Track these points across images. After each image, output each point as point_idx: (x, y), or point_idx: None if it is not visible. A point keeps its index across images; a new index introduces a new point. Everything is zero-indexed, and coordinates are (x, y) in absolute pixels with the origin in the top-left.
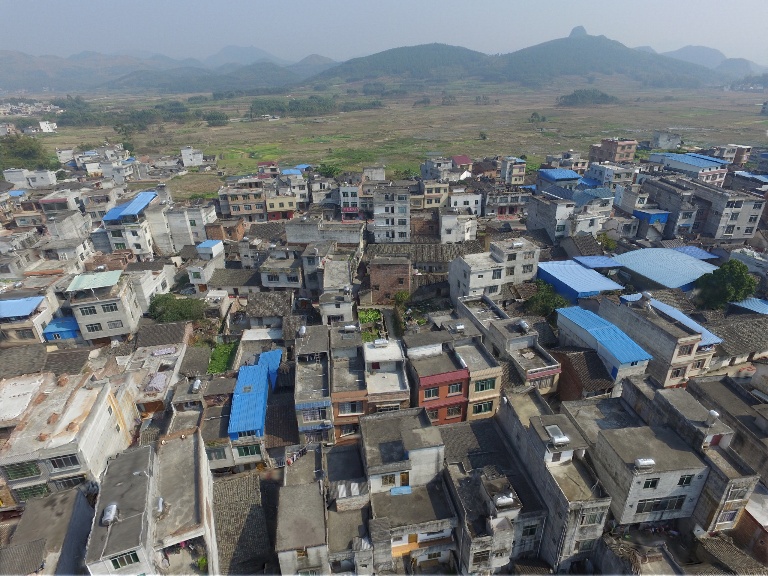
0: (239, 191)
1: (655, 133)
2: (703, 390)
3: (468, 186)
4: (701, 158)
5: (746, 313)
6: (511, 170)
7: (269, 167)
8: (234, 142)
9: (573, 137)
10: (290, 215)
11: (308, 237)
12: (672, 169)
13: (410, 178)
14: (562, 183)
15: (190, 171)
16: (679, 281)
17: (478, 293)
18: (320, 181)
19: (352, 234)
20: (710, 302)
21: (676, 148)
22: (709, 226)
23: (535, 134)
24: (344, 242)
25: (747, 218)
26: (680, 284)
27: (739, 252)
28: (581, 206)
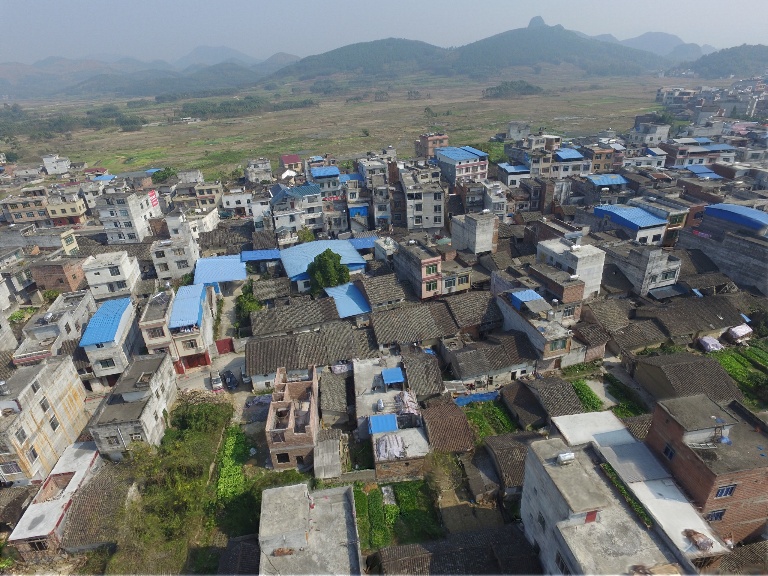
0: (20, 199)
1: (508, 125)
2: None
3: (256, 186)
4: (468, 151)
5: None
6: None
7: (94, 173)
8: (128, 147)
9: (455, 131)
10: (77, 220)
11: (15, 242)
12: (442, 163)
13: (238, 179)
14: (322, 180)
15: (48, 179)
16: (301, 270)
17: (101, 289)
18: (114, 186)
19: (53, 238)
20: (313, 288)
21: None
22: (406, 217)
23: (422, 129)
24: (49, 246)
25: (432, 208)
26: (298, 273)
27: (383, 241)
28: (286, 203)
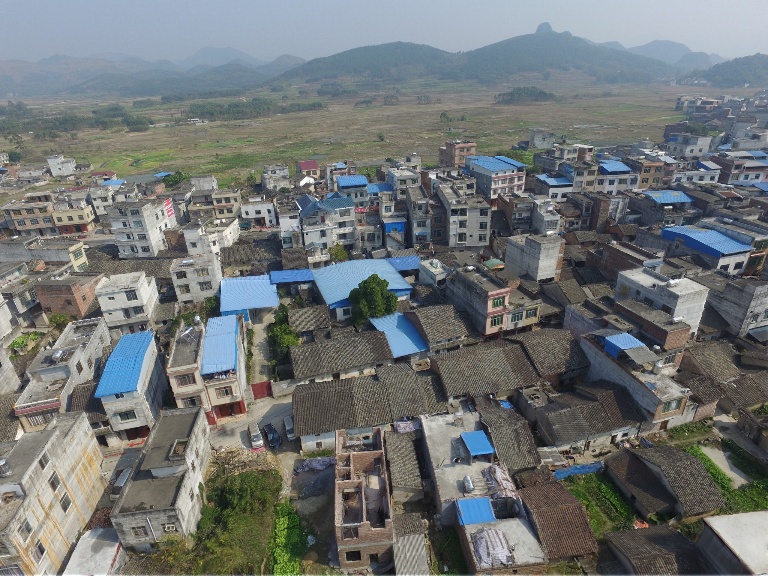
0: (23, 205)
1: (532, 133)
2: (153, 425)
3: (276, 194)
4: (504, 161)
5: (372, 330)
6: (332, 176)
7: (102, 177)
8: (135, 148)
9: (472, 137)
10: (84, 228)
11: (18, 256)
12: (475, 173)
13: (254, 185)
14: (350, 190)
15: (53, 181)
16: (340, 296)
17: (115, 315)
18: (124, 192)
19: (60, 252)
20: (356, 318)
21: (552, 147)
22: (447, 234)
23: (438, 134)
24: (55, 260)
25: (477, 225)
26: (338, 299)
27: (429, 263)
28: (316, 217)
